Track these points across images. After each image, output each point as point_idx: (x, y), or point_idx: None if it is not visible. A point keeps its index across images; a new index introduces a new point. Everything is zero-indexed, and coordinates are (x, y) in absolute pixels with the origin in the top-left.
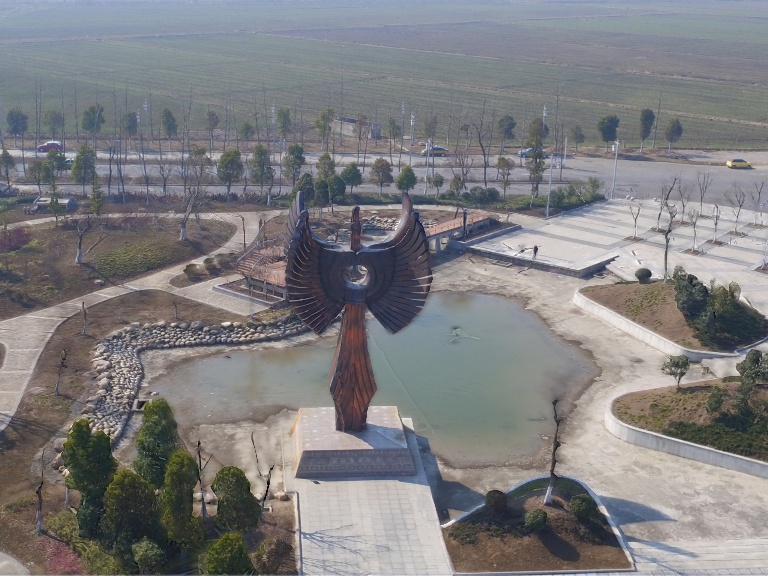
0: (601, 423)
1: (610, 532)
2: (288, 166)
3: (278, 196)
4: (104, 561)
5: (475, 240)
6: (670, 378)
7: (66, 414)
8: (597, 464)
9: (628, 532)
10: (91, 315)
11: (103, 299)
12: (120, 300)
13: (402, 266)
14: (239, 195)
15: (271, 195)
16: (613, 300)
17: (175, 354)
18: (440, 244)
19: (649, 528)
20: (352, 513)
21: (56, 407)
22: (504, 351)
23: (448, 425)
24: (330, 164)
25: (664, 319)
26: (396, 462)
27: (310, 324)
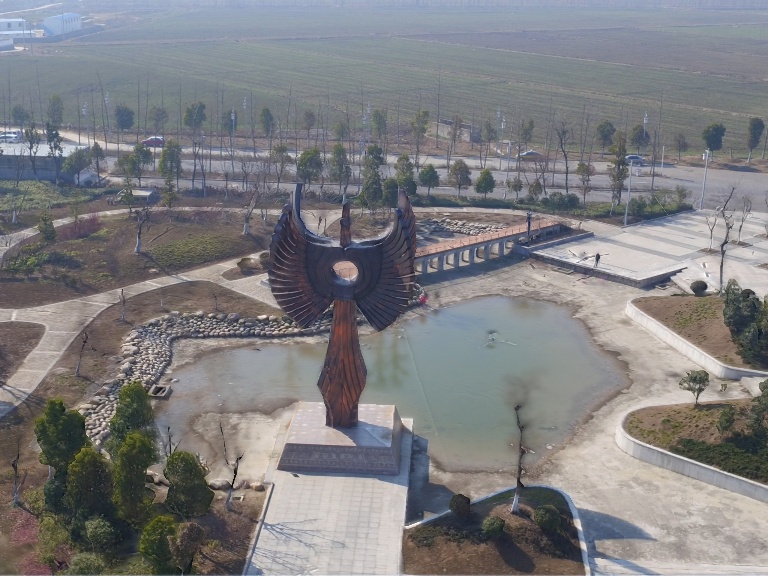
0: (613, 436)
1: (576, 546)
2: (366, 166)
3: (356, 195)
4: (56, 535)
5: (540, 246)
6: (702, 395)
7: (80, 395)
8: (593, 477)
9: (601, 548)
10: (136, 302)
11: (153, 288)
12: (169, 289)
13: (388, 264)
14: (318, 193)
15: (349, 194)
16: (663, 312)
17: (207, 344)
18: (503, 248)
19: (625, 545)
20: (320, 508)
21: (73, 387)
22: (537, 358)
23: (454, 428)
24: (408, 165)
25: (710, 334)
26: (378, 461)
27: (295, 317)
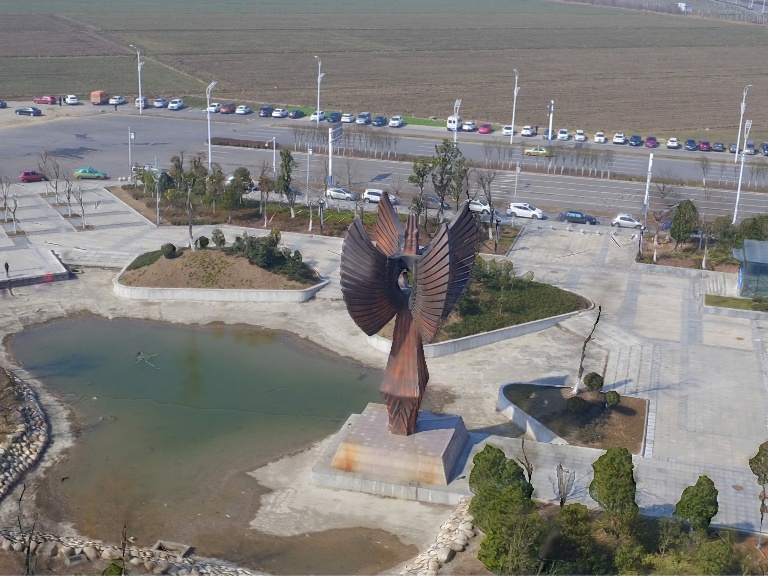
0: None
1: None
2: None
3: None
4: None
5: None
6: (330, 314)
7: None
8: (463, 376)
9: None
10: None
11: None
12: None
13: None
14: None
15: None
16: (175, 280)
17: (18, 508)
18: None
19: None
20: None
21: None
22: (201, 352)
23: (343, 411)
24: None
25: (248, 277)
26: None
27: None
